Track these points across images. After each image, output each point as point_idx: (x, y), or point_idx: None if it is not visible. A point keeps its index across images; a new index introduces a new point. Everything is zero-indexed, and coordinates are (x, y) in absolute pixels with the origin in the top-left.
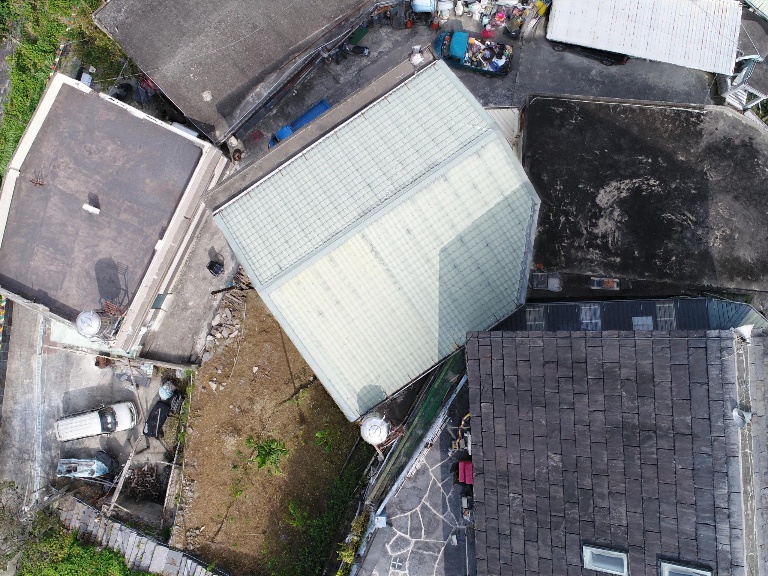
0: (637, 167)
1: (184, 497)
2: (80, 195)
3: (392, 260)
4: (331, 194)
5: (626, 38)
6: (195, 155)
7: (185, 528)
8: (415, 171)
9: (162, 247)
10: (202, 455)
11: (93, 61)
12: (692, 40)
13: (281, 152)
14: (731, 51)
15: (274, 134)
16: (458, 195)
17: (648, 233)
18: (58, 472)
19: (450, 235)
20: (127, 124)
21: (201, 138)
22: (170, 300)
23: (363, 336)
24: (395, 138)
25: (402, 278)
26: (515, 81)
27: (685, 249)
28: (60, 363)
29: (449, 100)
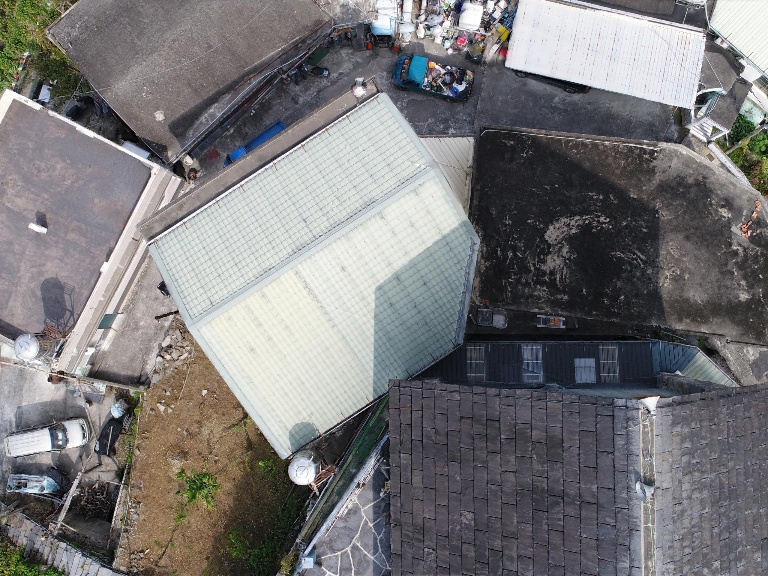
0: (588, 203)
1: (129, 519)
2: (28, 213)
3: (326, 297)
4: (266, 228)
5: (586, 68)
6: (145, 176)
7: (130, 550)
8: (351, 207)
9: (108, 269)
10: (149, 477)
11: (50, 74)
12: (653, 72)
13: (219, 182)
14: (692, 84)
15: (229, 155)
16: (395, 233)
17: (597, 271)
18: (8, 487)
19: (386, 273)
20: (77, 142)
21: (155, 157)
22: (121, 319)
23: (296, 373)
24: (333, 172)
25: (336, 316)
26: (476, 106)
27: (634, 288)
28: (14, 377)
29: (390, 135)
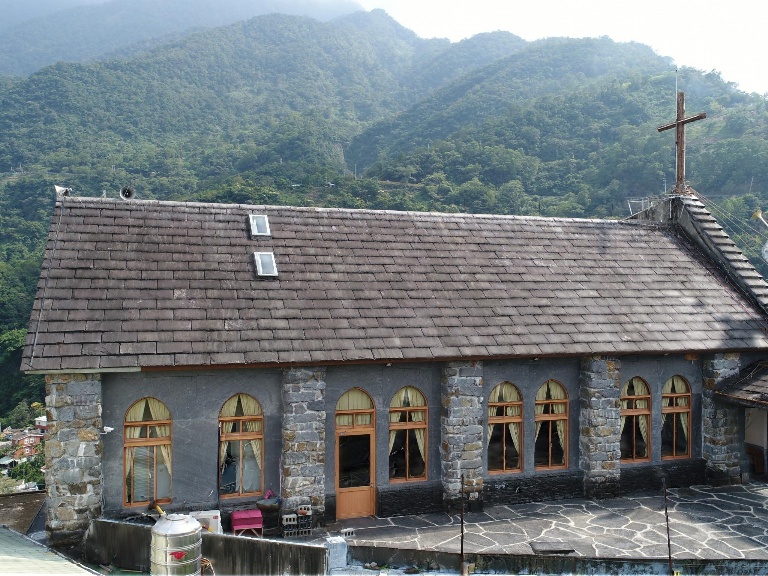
0: None
1: None
2: None
3: None
4: None
5: None
6: None
7: None
8: None
9: None
10: None
11: None
12: None
13: None
14: None
15: None
16: None
17: None
18: None
19: None
20: None
21: None
22: None
23: None
24: None
25: None
26: None
27: None
28: None
29: None
